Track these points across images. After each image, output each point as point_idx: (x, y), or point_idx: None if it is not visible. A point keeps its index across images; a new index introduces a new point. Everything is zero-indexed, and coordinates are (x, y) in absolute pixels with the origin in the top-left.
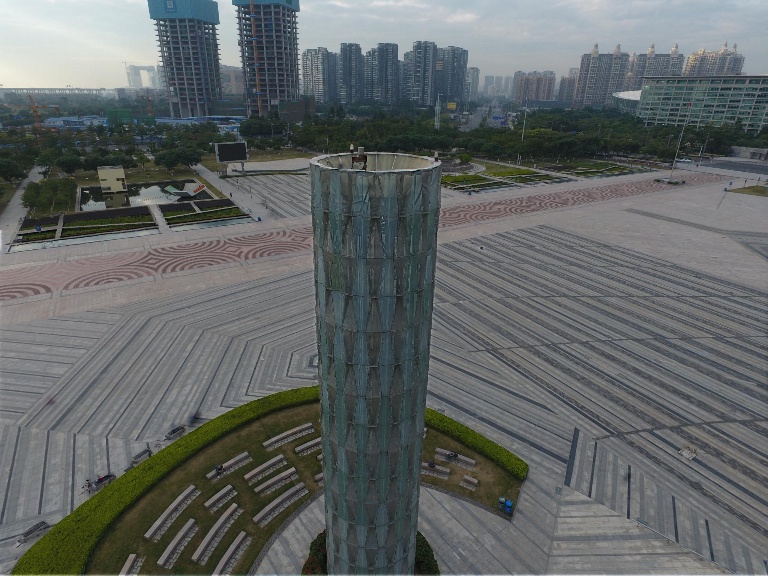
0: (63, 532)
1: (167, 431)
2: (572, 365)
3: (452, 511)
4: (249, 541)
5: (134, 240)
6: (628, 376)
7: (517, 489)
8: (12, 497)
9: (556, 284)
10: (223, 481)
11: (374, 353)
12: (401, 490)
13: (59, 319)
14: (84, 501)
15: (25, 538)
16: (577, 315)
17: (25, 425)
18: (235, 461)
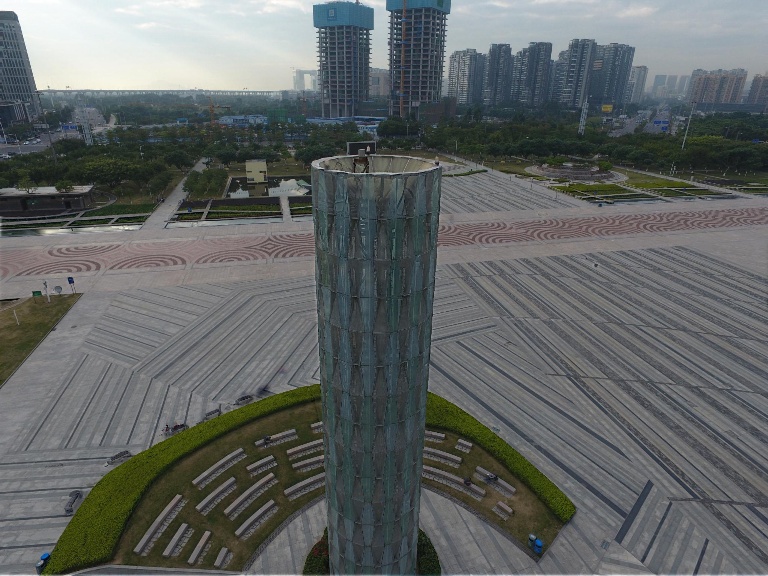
0: (137, 463)
1: (238, 397)
2: (668, 410)
3: (475, 534)
4: (276, 510)
5: (260, 226)
6: (740, 435)
7: (555, 530)
8: (113, 426)
9: (677, 315)
10: (268, 451)
11: (357, 352)
12: (389, 494)
13: (185, 287)
14: (160, 442)
15: (112, 461)
16: (693, 354)
17: (137, 370)
18: (282, 435)
